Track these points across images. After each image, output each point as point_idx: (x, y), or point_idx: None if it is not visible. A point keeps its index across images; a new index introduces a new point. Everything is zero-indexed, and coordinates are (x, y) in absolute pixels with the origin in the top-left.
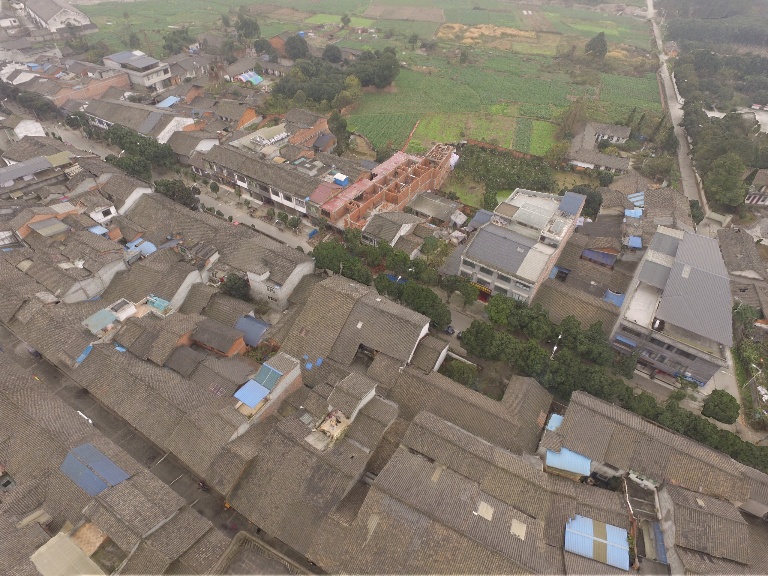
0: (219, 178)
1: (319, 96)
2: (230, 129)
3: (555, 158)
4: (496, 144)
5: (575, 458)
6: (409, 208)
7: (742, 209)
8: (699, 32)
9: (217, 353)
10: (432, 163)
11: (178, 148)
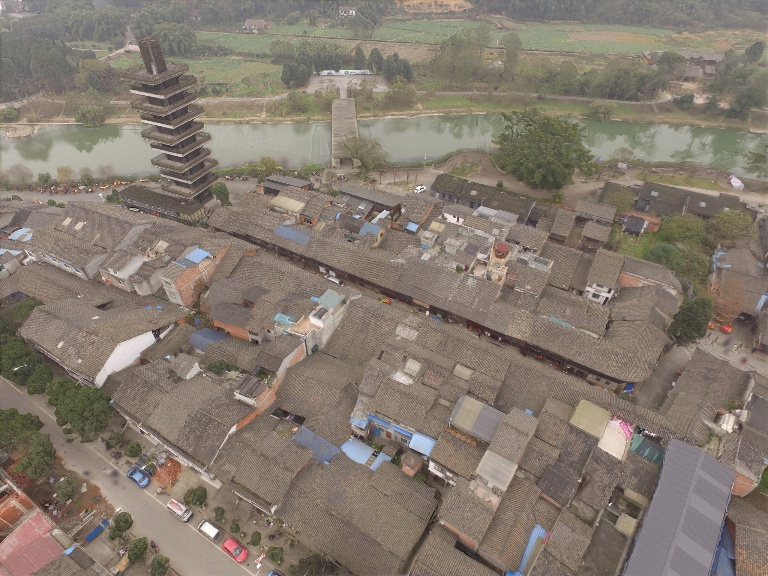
0: None
1: None
2: None
3: None
4: None
5: (0, 253)
6: None
7: None
8: None
9: None
10: None
11: None
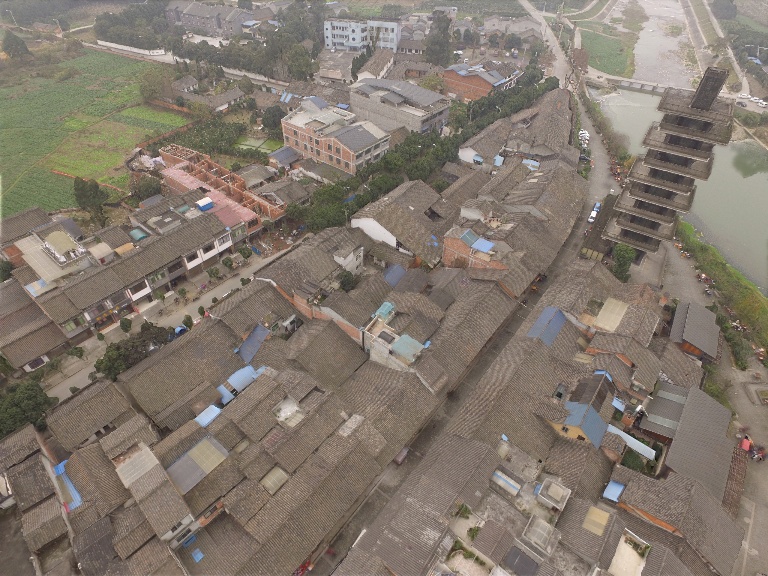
0: (91, 329)
1: None
2: None
3: (208, 113)
4: (162, 133)
5: (497, 158)
6: None
7: None
8: (41, 8)
9: (422, 292)
10: None
11: None
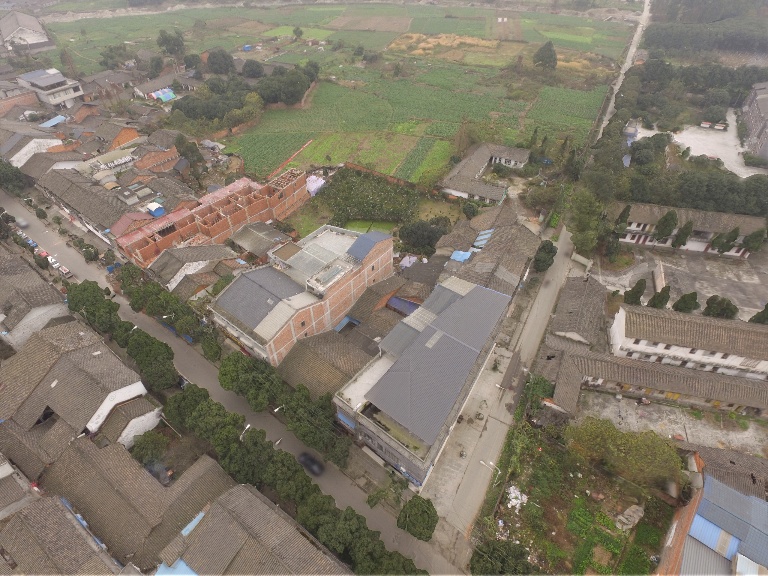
0: None
1: (215, 114)
2: (101, 150)
3: (426, 185)
4: (371, 168)
5: (188, 575)
6: (229, 241)
7: (616, 251)
8: (677, 38)
9: None
10: (277, 190)
11: (32, 170)
